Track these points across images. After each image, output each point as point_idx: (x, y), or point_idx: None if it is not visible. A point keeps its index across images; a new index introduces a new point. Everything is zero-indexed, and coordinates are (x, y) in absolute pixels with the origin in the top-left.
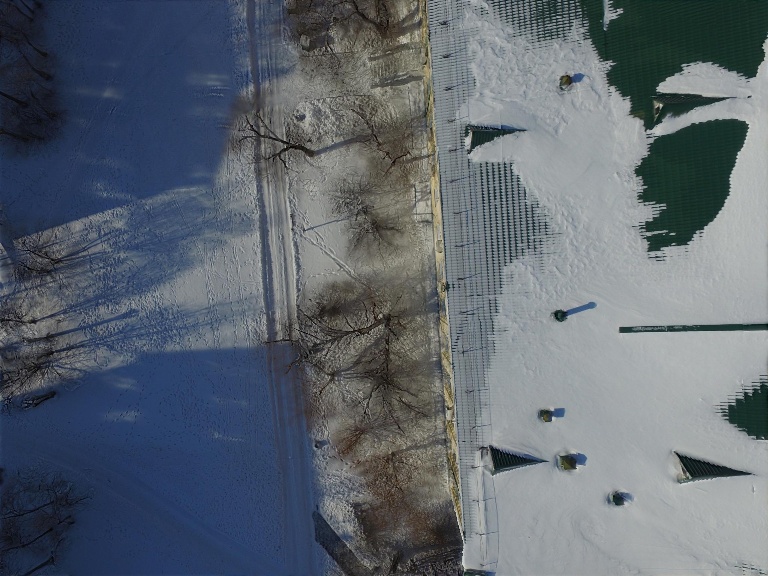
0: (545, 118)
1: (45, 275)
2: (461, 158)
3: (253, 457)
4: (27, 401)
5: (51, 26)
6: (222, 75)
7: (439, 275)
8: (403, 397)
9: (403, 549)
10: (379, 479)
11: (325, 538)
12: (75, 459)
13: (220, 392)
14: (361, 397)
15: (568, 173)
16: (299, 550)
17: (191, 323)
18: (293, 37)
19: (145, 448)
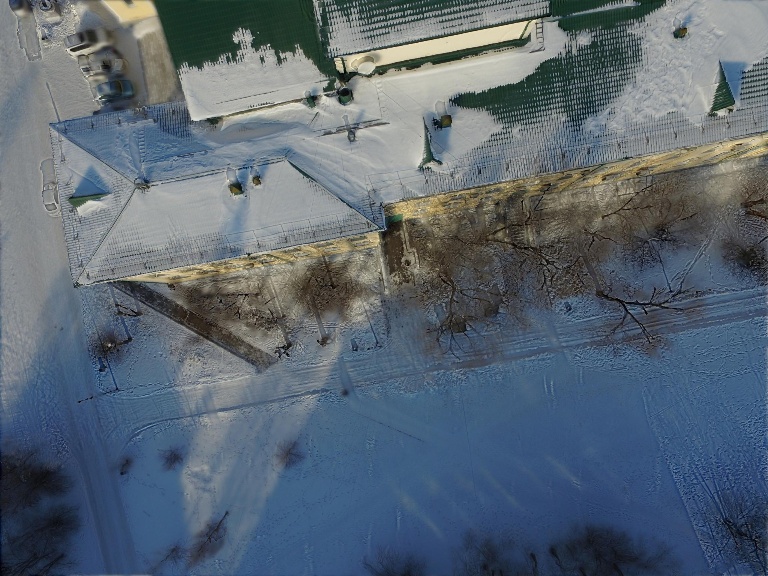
0: (709, 47)
1: None
2: (735, 117)
3: None
4: None
5: (505, 552)
6: (534, 384)
7: None
8: None
9: None
10: None
11: None
12: None
13: None
14: None
15: (757, 22)
16: None
17: None
18: (493, 322)
19: None
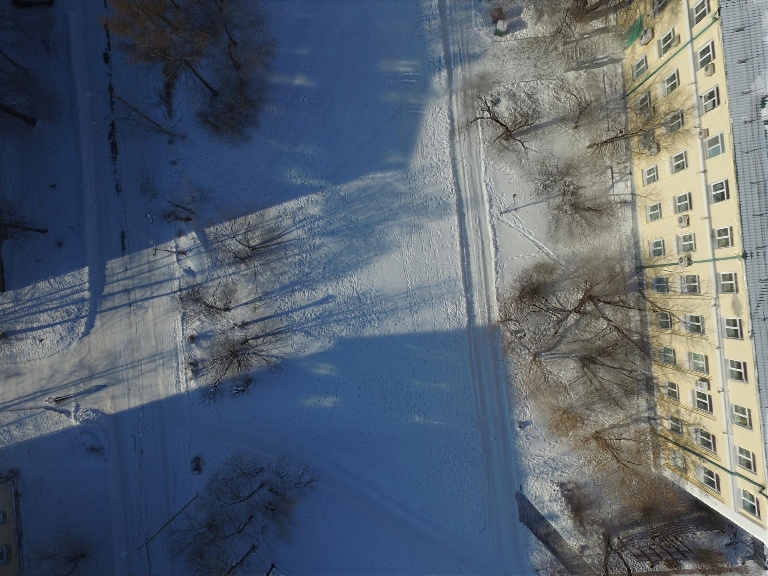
0: None
1: (240, 263)
2: (757, 129)
3: (455, 439)
4: (237, 387)
5: (241, 15)
6: (414, 61)
7: (647, 254)
8: (604, 376)
9: (609, 527)
10: (583, 458)
11: (529, 518)
12: (272, 446)
13: (421, 375)
14: (562, 377)
15: None
16: (503, 531)
17: (390, 307)
18: (485, 23)
19: (345, 433)
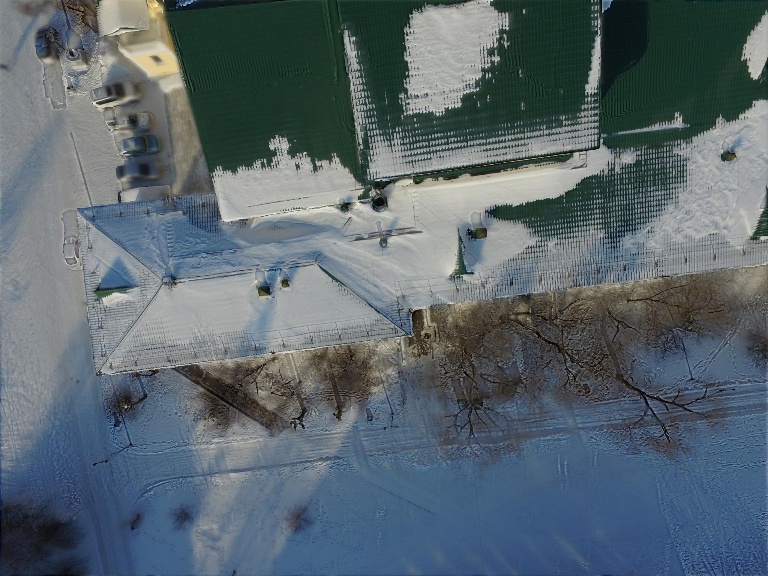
0: (756, 172)
1: None
2: None
3: None
4: None
5: None
6: (548, 464)
7: None
8: None
9: None
10: None
11: None
12: None
13: None
14: None
15: None
16: None
17: None
18: (510, 400)
19: None
